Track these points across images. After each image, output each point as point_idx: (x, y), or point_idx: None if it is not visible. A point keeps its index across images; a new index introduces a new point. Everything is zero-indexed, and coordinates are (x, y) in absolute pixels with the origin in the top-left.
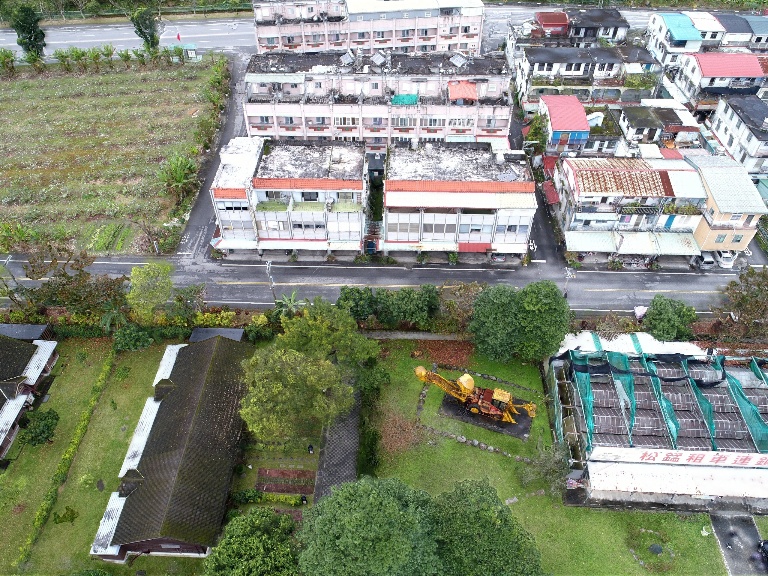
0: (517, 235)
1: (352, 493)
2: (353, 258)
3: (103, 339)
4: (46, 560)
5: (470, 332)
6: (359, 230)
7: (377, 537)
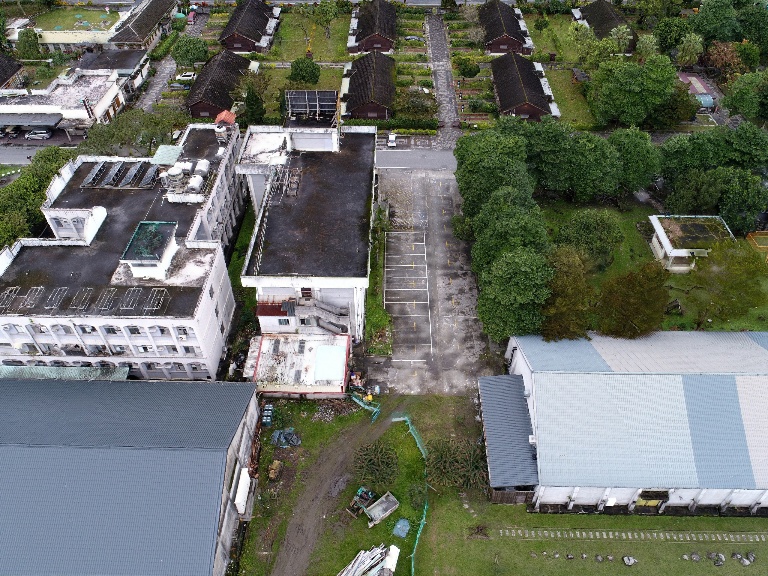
0: None
1: (711, 0)
2: None
3: (532, 14)
4: (569, 57)
5: None
6: None
7: (725, 8)
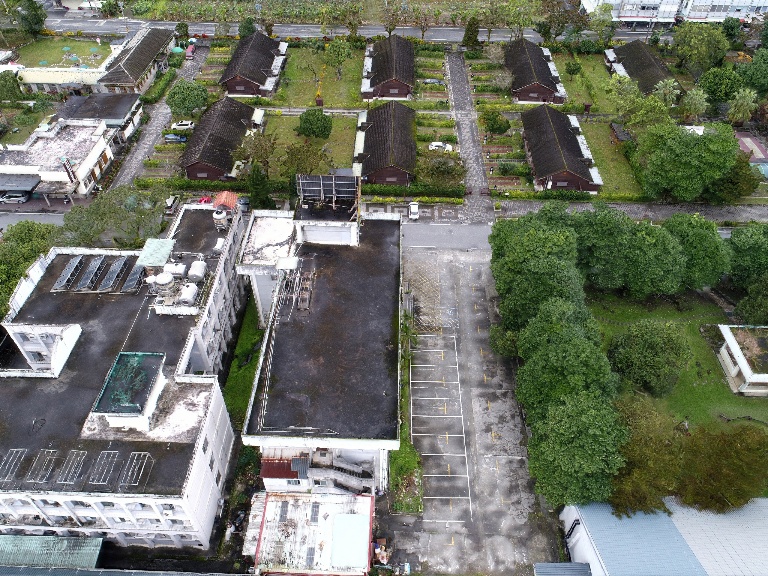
0: (760, 13)
1: None
2: (666, 30)
3: (560, 54)
4: (605, 107)
5: (762, 37)
6: (676, 10)
7: None
